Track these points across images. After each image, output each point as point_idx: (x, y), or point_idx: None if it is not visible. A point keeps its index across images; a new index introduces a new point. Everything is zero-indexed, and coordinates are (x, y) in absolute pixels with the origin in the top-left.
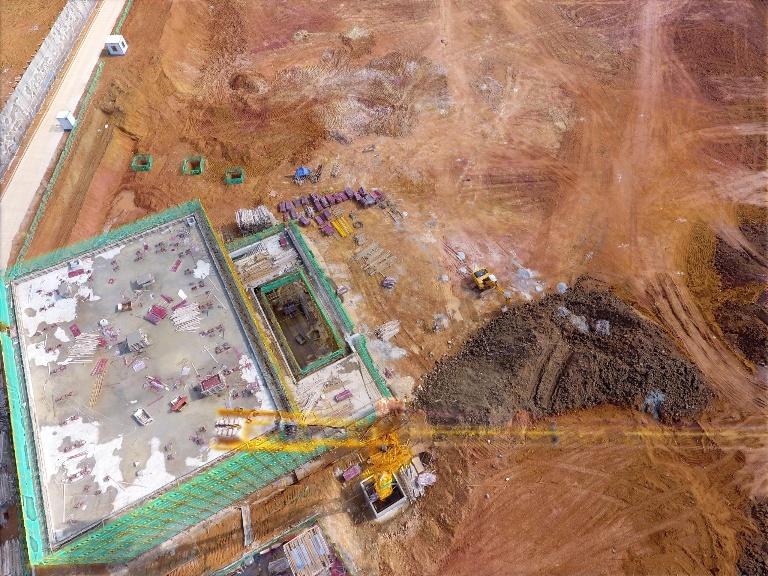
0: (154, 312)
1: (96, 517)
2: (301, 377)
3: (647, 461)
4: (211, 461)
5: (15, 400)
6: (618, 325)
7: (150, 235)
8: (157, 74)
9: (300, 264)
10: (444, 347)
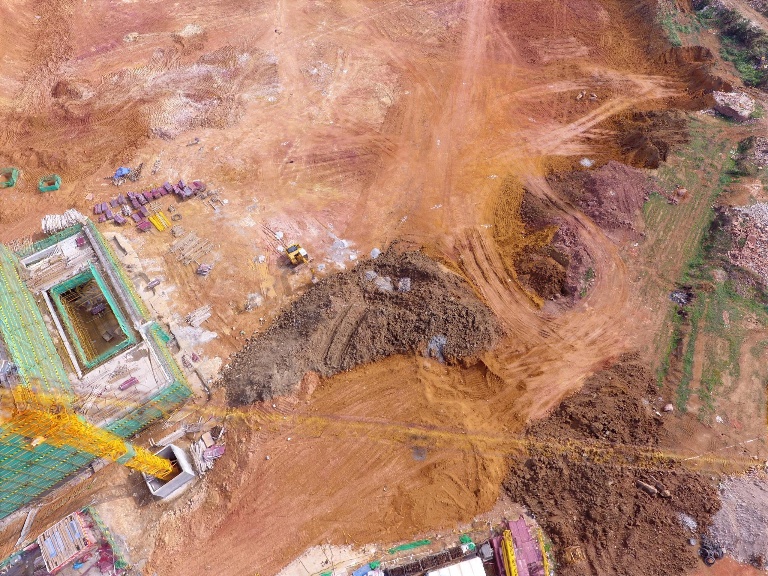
0: None
1: None
2: (87, 371)
3: (424, 401)
4: None
5: None
6: (418, 280)
7: None
8: None
9: (96, 261)
10: (256, 325)
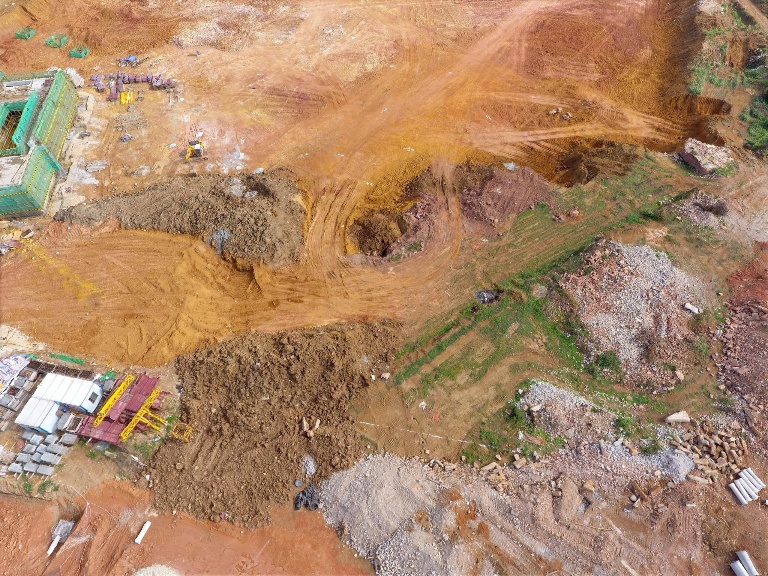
0: None
1: None
2: None
3: (172, 270)
4: None
5: None
6: (261, 195)
7: None
8: None
9: None
10: (129, 187)
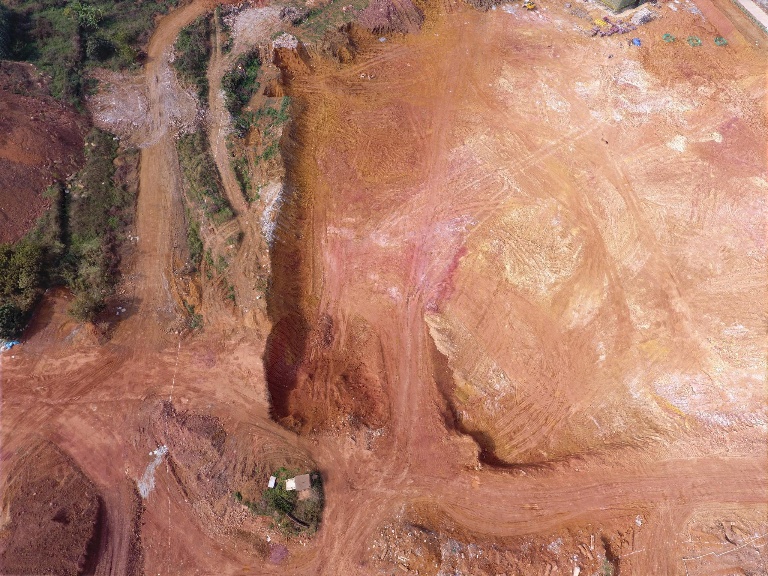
0: None
1: None
2: None
3: None
4: None
5: None
6: None
7: None
8: None
9: None
10: None
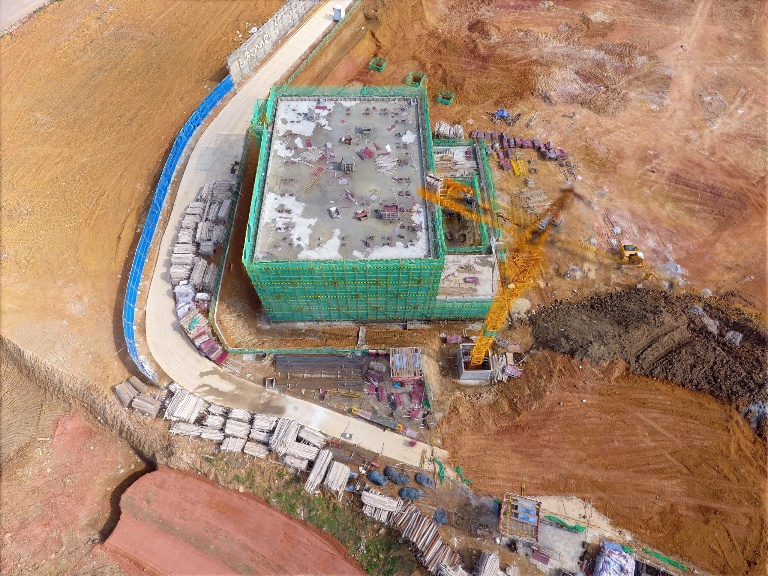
0: (365, 151)
1: (285, 258)
2: (444, 253)
3: (726, 451)
4: (370, 259)
5: (260, 168)
6: (751, 341)
7: (380, 101)
8: (415, 0)
9: (476, 175)
10: (568, 293)
